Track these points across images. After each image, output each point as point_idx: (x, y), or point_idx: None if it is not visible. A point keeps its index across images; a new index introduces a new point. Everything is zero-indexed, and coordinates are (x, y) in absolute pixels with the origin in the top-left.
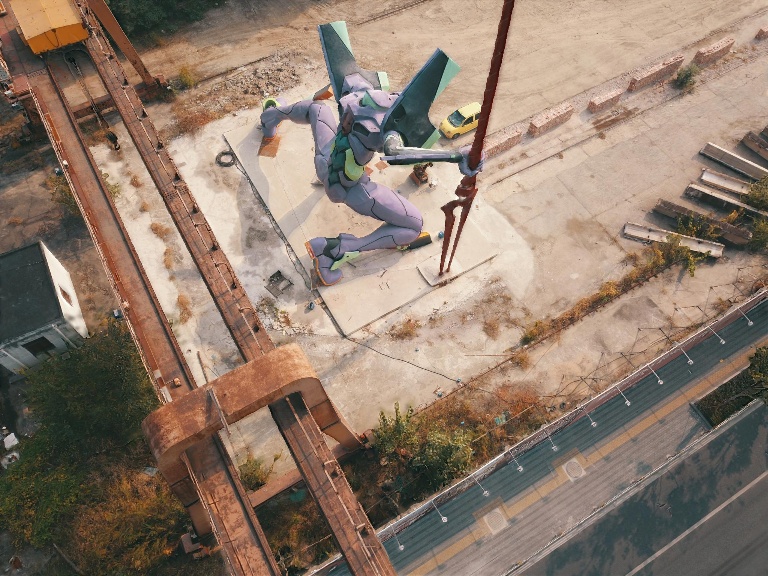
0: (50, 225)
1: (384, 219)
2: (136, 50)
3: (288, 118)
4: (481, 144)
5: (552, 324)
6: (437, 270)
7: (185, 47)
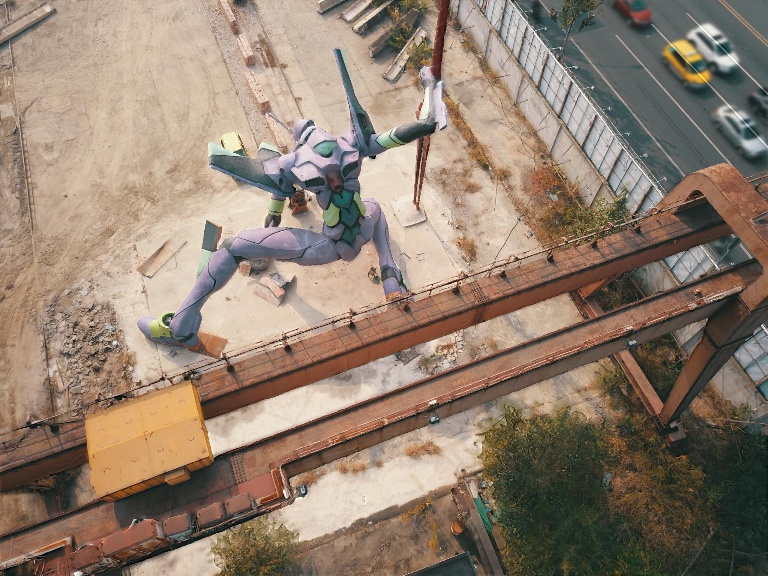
0: None
1: None
2: None
3: (210, 295)
4: None
5: (473, 146)
6: (414, 210)
7: None
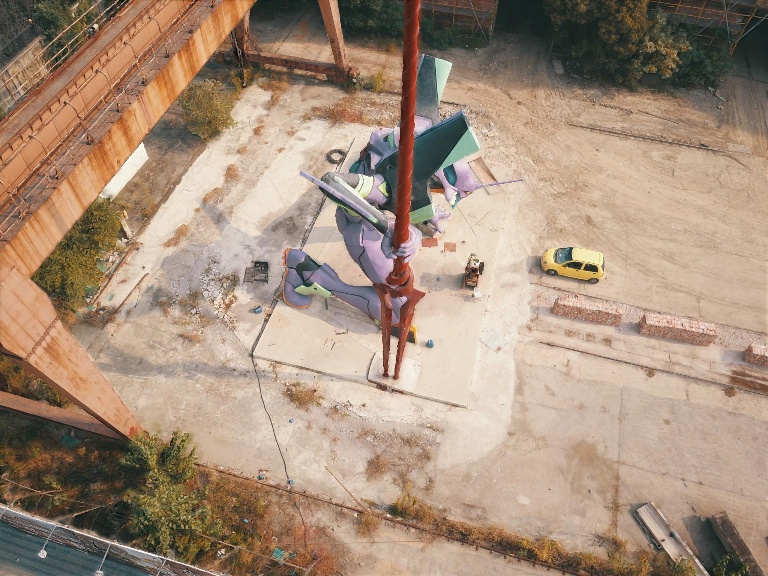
0: (178, 121)
1: None
2: (369, 45)
3: None
4: (401, 223)
5: (439, 521)
6: None
7: None
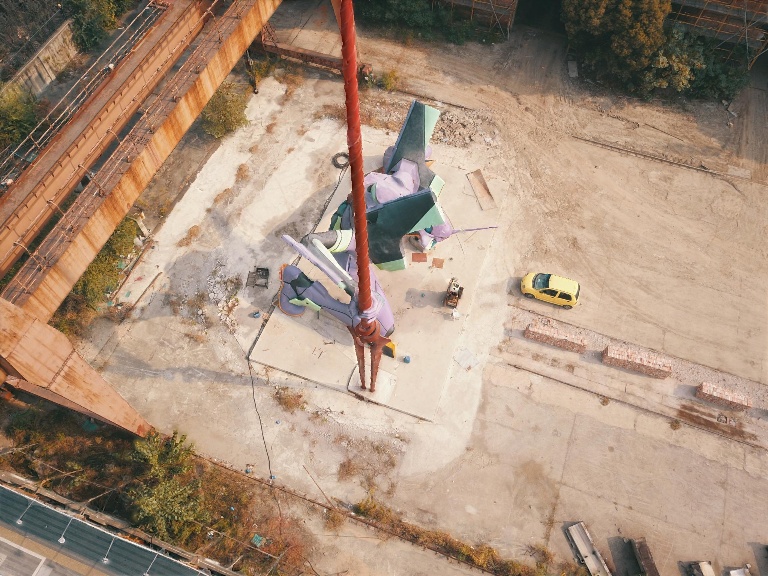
0: None
1: None
2: (386, 36)
3: None
4: (363, 296)
5: (395, 523)
6: None
7: (421, 57)
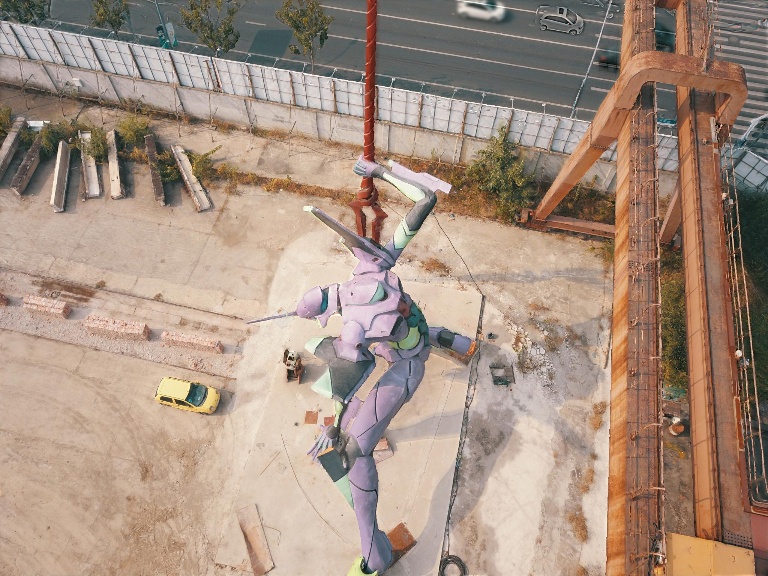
0: None
1: None
2: None
3: None
4: None
5: (337, 197)
6: None
7: None
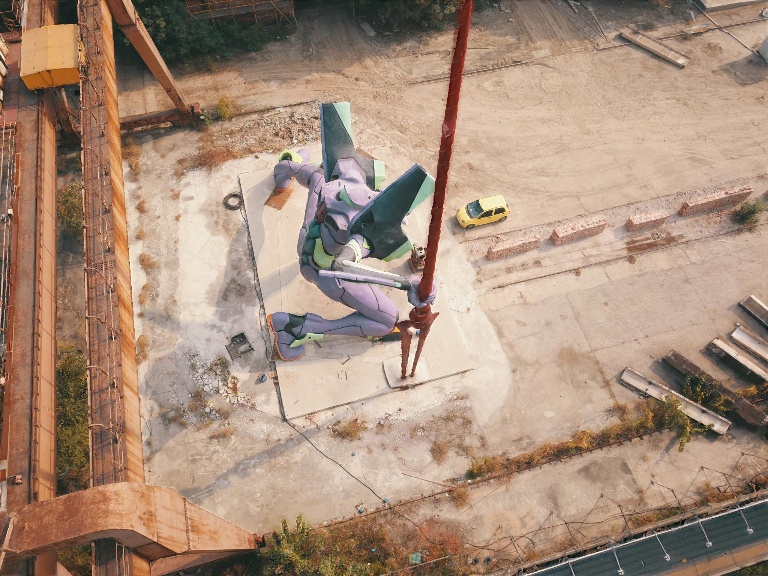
0: None
1: (355, 308)
2: (187, 71)
3: None
4: (429, 281)
5: (506, 464)
6: None
7: (234, 77)
